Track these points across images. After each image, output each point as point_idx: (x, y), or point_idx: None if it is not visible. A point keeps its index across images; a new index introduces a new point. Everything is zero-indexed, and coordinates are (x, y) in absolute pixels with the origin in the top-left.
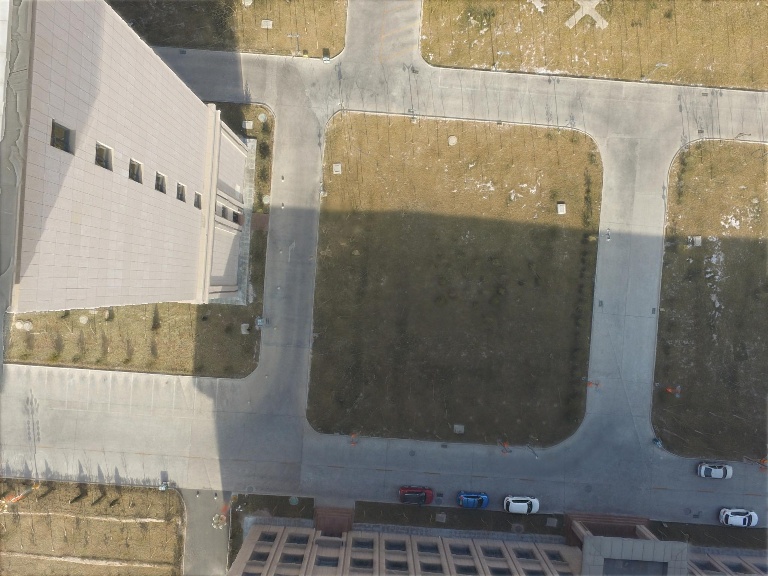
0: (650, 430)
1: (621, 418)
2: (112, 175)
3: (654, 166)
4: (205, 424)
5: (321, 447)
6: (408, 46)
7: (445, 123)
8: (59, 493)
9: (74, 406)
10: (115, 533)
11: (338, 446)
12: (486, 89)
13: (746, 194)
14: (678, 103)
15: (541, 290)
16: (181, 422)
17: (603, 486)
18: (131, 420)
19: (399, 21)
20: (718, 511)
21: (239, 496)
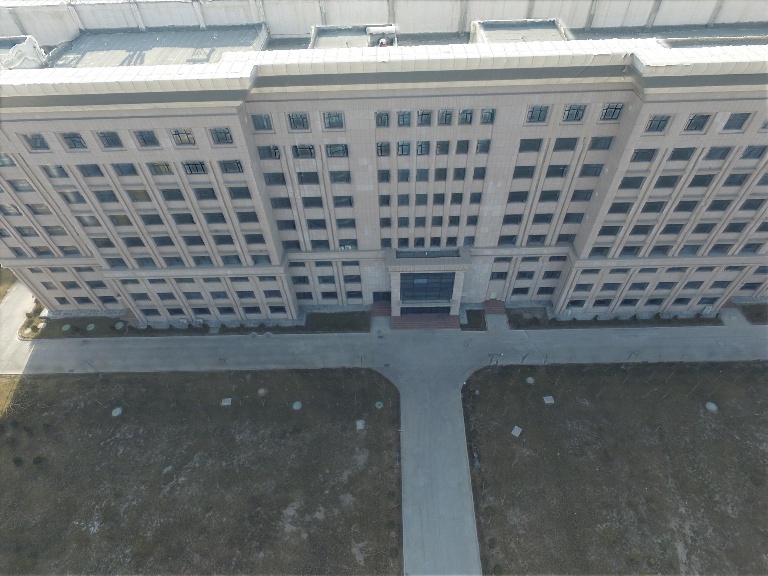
0: None
1: None
2: None
3: None
4: None
5: None
6: None
7: None
8: None
9: None
10: None
11: None
12: None
13: None
14: None
15: None
16: None
17: None
18: None
19: None
20: None
21: None
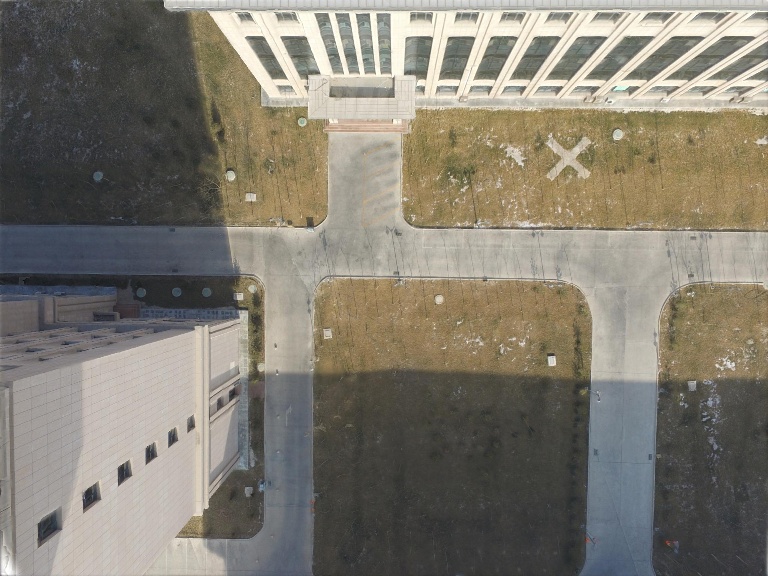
0: (652, 574)
1: (622, 563)
2: (101, 503)
3: (644, 313)
4: None
5: None
6: (390, 209)
7: (431, 282)
8: None
9: None
10: None
11: None
12: (470, 247)
13: (741, 336)
14: (666, 248)
15: (535, 441)
16: None
17: None
18: None
19: (379, 185)
20: None
21: None
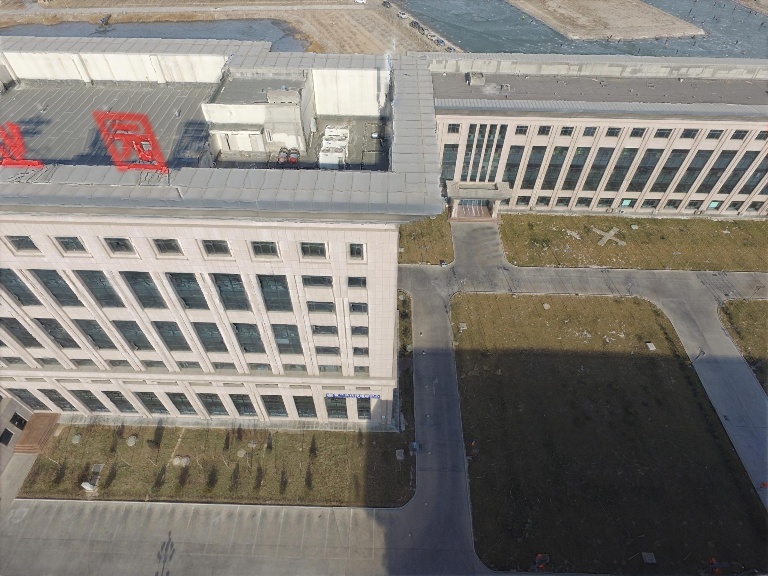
0: None
1: None
2: None
3: (706, 316)
4: (361, 566)
5: None
6: (497, 257)
7: (537, 296)
8: None
9: (214, 550)
10: None
11: None
12: (559, 277)
13: None
14: (699, 280)
15: (666, 409)
16: (334, 564)
17: None
18: (276, 565)
19: (488, 246)
20: None
21: None
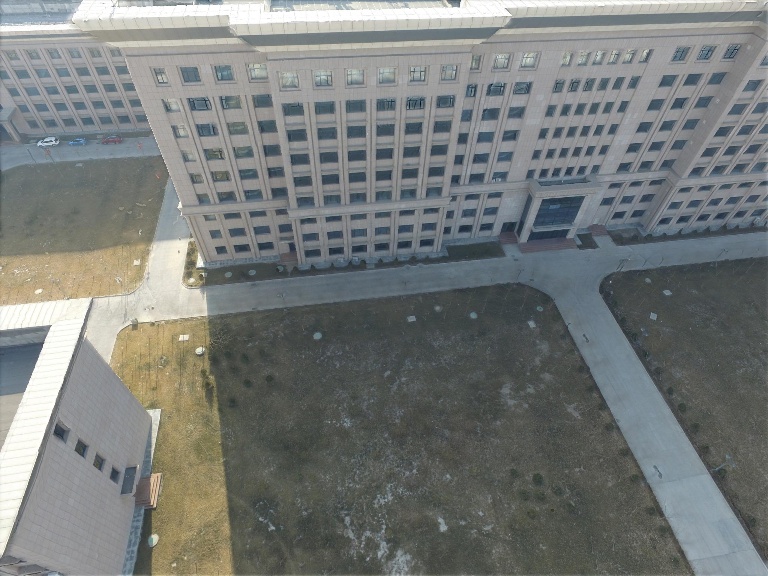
0: None
1: None
2: None
3: None
4: None
5: None
6: None
7: None
8: None
9: None
10: None
11: (156, 152)
12: None
13: None
14: None
15: None
16: None
17: None
18: None
19: None
20: None
21: None
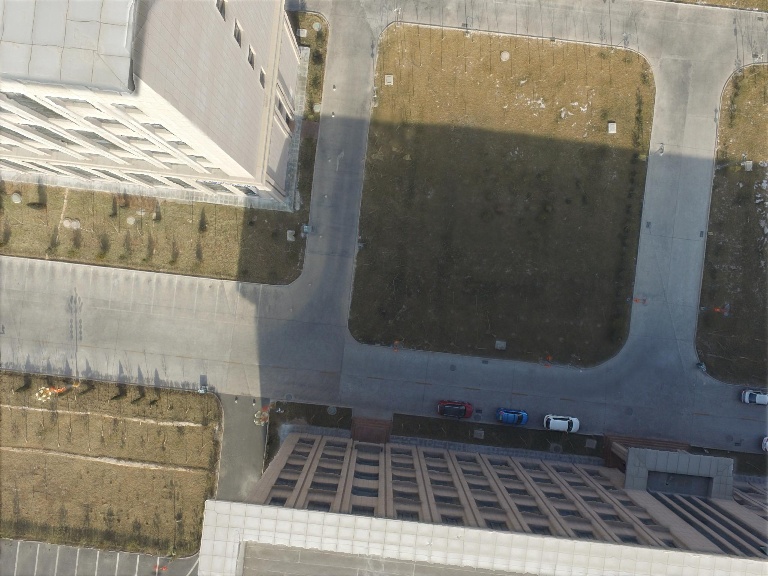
0: (694, 355)
1: (665, 341)
2: None
3: (707, 89)
4: (247, 330)
5: (361, 358)
6: None
7: (498, 38)
8: (98, 393)
9: (117, 306)
10: (152, 436)
11: (379, 357)
12: (541, 6)
13: None
14: (733, 27)
15: (588, 209)
16: (223, 327)
17: (644, 409)
18: (173, 323)
19: None
20: (761, 439)
21: (277, 403)
